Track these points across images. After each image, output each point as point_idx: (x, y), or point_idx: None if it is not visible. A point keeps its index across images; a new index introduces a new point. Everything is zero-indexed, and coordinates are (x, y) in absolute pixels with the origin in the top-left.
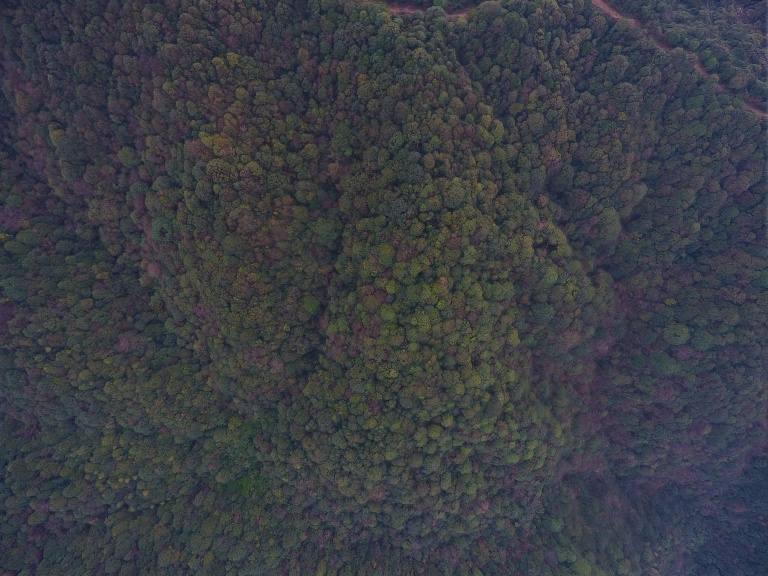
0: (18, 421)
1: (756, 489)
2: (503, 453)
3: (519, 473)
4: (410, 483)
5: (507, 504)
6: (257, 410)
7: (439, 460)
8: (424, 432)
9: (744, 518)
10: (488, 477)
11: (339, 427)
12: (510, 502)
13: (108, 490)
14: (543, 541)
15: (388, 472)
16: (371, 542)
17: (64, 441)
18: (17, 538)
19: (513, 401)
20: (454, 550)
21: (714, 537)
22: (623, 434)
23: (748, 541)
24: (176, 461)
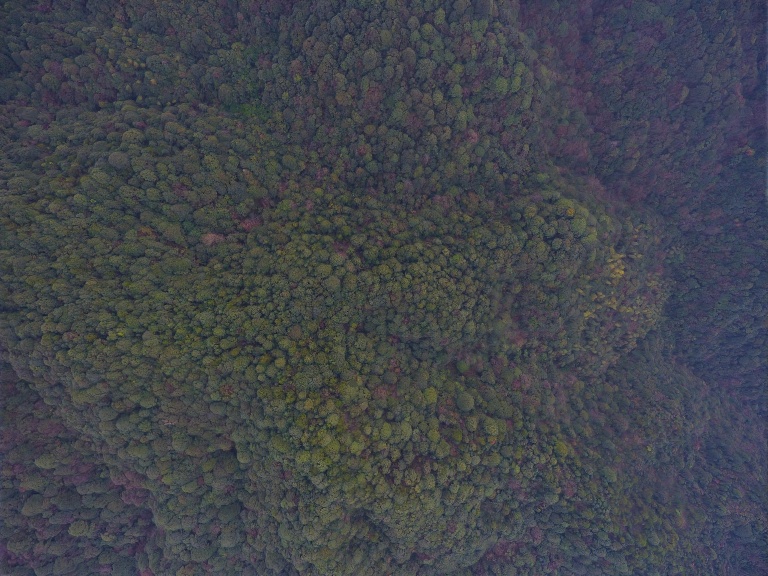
0: (32, 1)
1: (732, 190)
2: (492, 76)
3: (507, 111)
4: (404, 84)
5: (495, 143)
6: (259, 25)
7: (431, 63)
8: (417, 21)
9: (721, 226)
10: (478, 113)
11: (337, 13)
12: (498, 148)
13: (117, 73)
14: (529, 190)
15: (383, 62)
16: (366, 187)
17: (76, 21)
18: (31, 98)
19: (502, 21)
20: (445, 197)
21: (693, 254)
22: (606, 119)
23: (724, 246)
24: (182, 65)
